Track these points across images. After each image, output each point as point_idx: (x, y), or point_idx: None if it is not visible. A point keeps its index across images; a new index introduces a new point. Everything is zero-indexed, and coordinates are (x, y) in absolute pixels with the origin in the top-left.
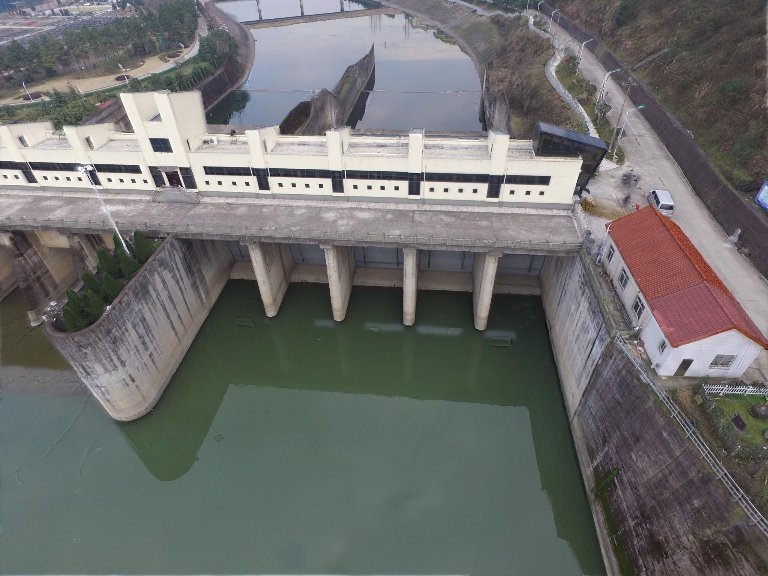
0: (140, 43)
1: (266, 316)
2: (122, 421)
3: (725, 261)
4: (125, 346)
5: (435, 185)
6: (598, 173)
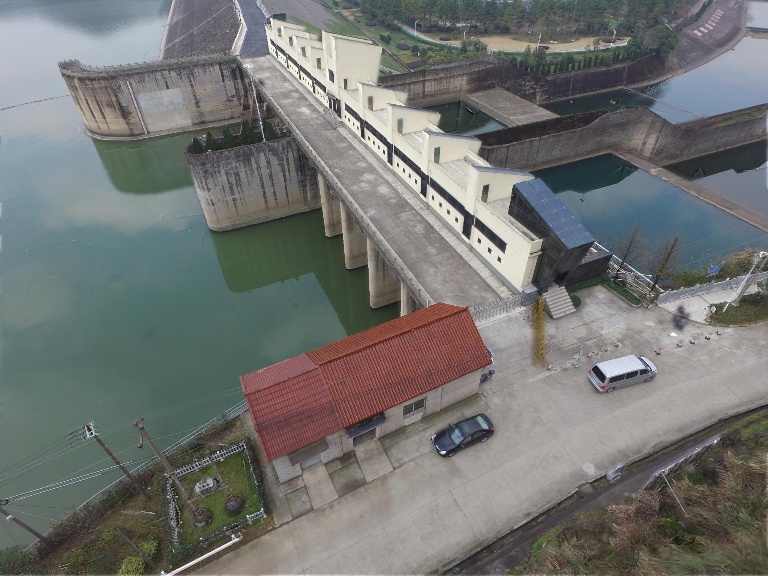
0: (588, 22)
1: (325, 233)
2: (208, 226)
3: (537, 467)
4: (214, 180)
5: (435, 194)
6: (653, 307)
